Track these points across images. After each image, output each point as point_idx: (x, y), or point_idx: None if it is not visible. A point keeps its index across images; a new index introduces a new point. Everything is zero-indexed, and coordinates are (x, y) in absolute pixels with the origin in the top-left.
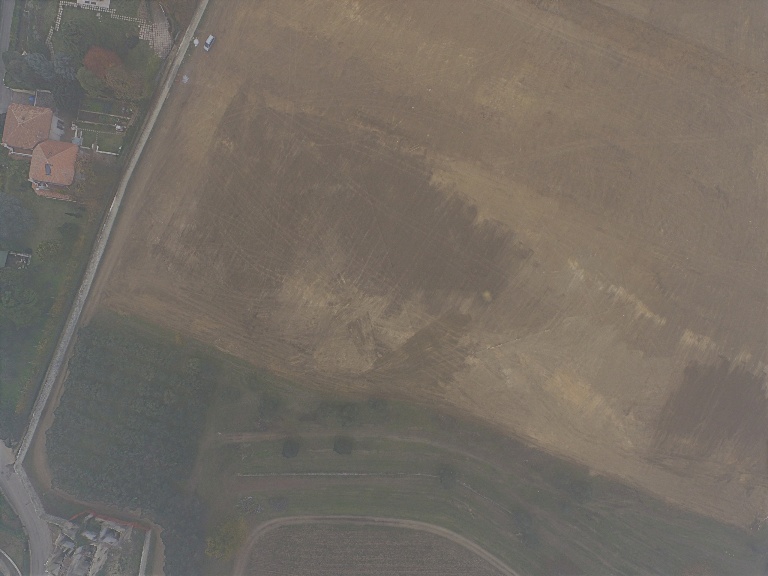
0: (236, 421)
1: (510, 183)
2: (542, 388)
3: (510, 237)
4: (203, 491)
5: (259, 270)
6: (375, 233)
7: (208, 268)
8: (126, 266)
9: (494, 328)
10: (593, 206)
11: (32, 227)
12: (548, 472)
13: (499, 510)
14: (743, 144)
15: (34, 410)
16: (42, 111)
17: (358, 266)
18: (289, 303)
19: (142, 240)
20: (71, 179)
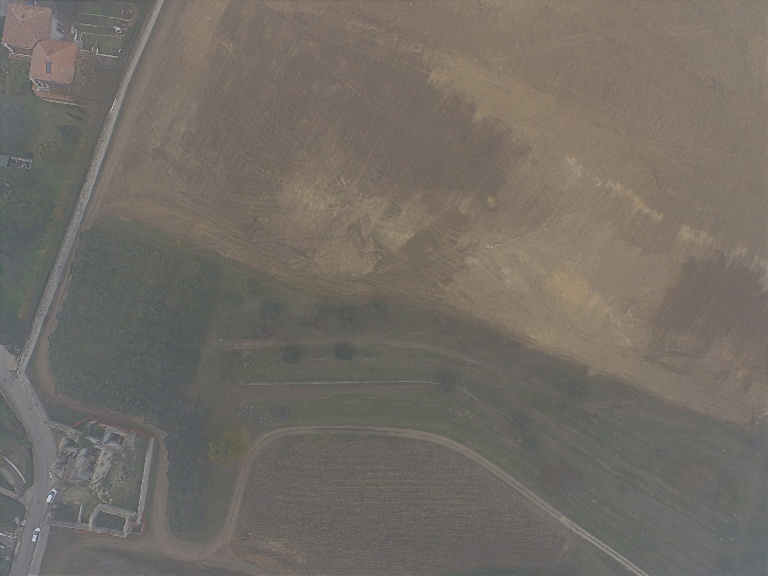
0: (238, 327)
1: (508, 79)
2: (541, 287)
3: (508, 134)
4: (205, 398)
5: (259, 173)
6: (374, 133)
7: (208, 172)
8: (127, 171)
9: (493, 227)
10: (590, 101)
11: (33, 129)
12: (547, 374)
13: (499, 416)
14: (738, 35)
15: (36, 317)
16: (42, 10)
17: (358, 167)
18: (289, 206)
19: (142, 144)
20: (71, 77)
